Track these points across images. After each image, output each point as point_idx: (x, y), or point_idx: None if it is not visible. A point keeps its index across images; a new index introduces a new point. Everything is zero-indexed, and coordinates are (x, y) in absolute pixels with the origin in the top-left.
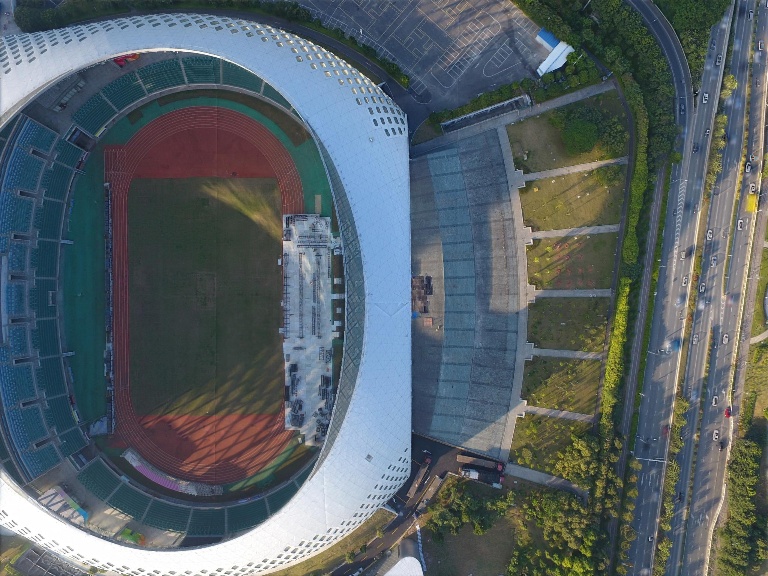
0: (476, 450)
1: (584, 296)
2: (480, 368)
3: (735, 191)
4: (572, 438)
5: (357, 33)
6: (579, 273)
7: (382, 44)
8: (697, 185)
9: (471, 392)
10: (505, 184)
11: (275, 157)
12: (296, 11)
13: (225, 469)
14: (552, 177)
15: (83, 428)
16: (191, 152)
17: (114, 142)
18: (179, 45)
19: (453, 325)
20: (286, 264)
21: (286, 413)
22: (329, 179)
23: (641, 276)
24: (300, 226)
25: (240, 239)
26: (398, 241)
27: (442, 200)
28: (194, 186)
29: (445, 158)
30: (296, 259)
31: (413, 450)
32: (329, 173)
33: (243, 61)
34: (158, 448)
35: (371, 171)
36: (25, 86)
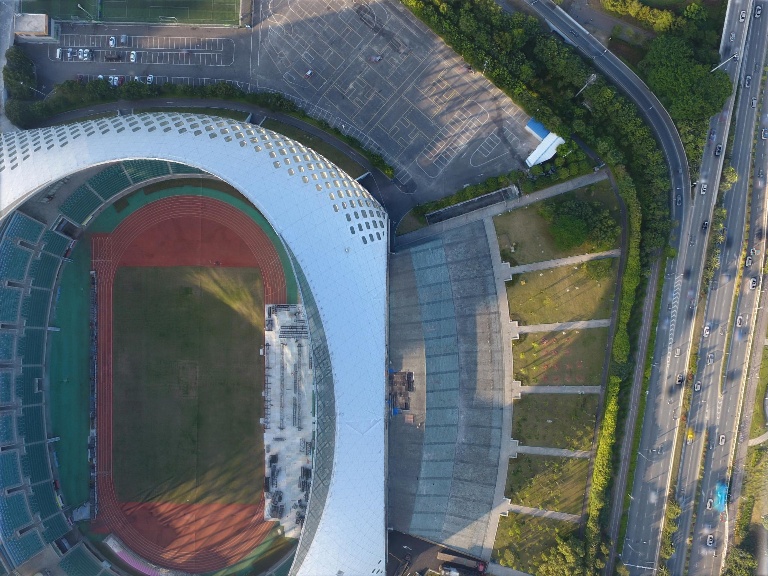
0: (457, 548)
1: (572, 393)
2: (463, 464)
3: (734, 286)
4: (557, 540)
5: (342, 122)
6: (567, 369)
7: (367, 133)
8: (694, 279)
9: (453, 488)
10: (491, 276)
11: (258, 246)
12: (280, 103)
13: (205, 558)
14: (540, 270)
15: (67, 513)
16: (175, 241)
17: (100, 230)
18: (156, 154)
19: (435, 422)
20: (267, 355)
21: (266, 504)
22: (301, 296)
23: (632, 373)
24: (282, 316)
25: (222, 328)
26: (372, 356)
27: (425, 294)
28: (178, 275)
29: (429, 250)
30: (278, 349)
31: (393, 546)
32: (301, 289)
33: (219, 171)
34: (139, 534)
35: (345, 284)
36: (6, 196)
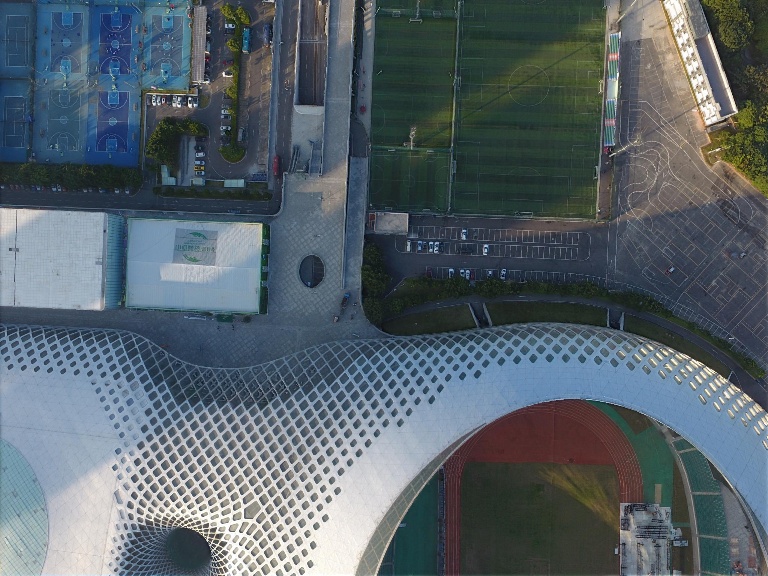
0: None
1: None
2: None
3: None
4: None
5: (704, 319)
6: None
7: (730, 331)
8: None
9: None
10: None
11: (614, 444)
12: (652, 307)
13: None
14: None
15: None
16: (527, 437)
17: None
18: (591, 395)
19: None
20: (626, 556)
21: None
22: (767, 557)
23: None
24: (639, 515)
25: (575, 526)
26: None
27: None
28: (529, 471)
29: None
30: (634, 549)
31: None
32: (765, 548)
33: (660, 416)
34: None
35: None
36: (437, 438)
